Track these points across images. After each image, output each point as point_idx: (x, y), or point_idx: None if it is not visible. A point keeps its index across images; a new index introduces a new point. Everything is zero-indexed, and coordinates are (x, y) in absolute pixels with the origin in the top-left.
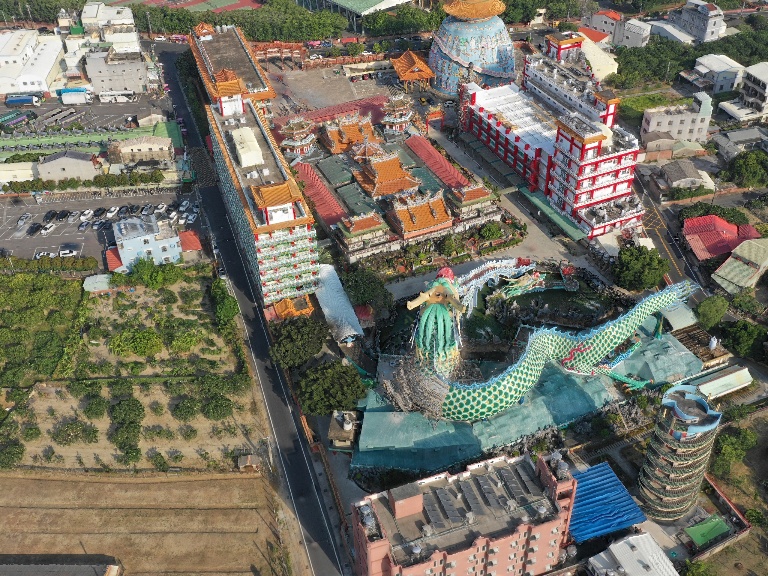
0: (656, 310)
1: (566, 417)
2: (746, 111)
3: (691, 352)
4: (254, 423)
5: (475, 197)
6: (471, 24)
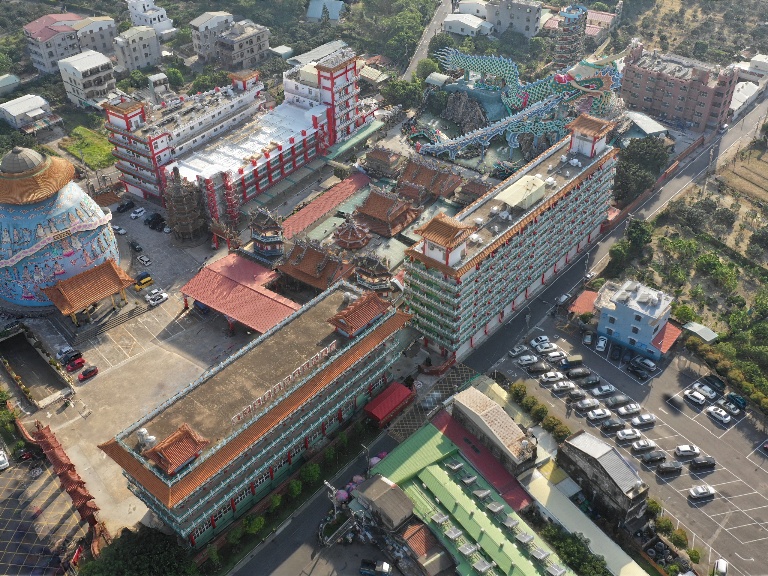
0: None
1: None
2: (113, 95)
3: None
4: (691, 196)
5: None
6: (65, 185)
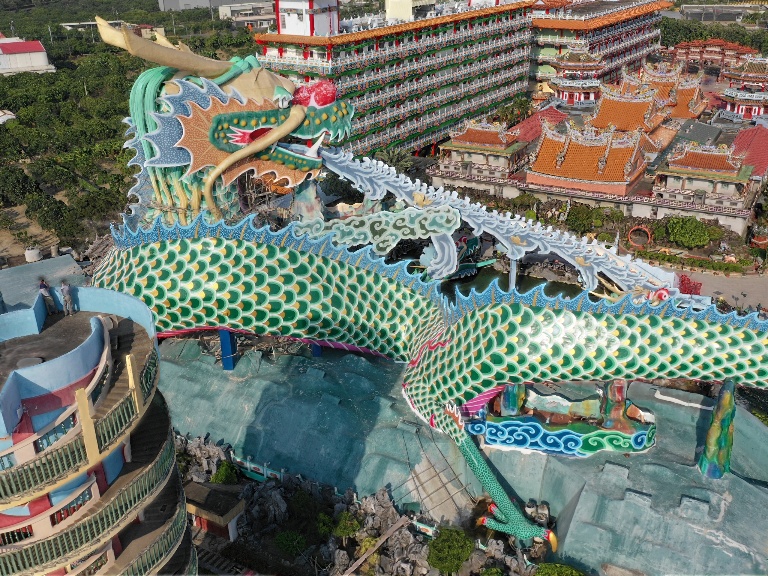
0: (724, 372)
1: (273, 455)
2: None
3: (766, 561)
4: None
5: (700, 165)
6: None
